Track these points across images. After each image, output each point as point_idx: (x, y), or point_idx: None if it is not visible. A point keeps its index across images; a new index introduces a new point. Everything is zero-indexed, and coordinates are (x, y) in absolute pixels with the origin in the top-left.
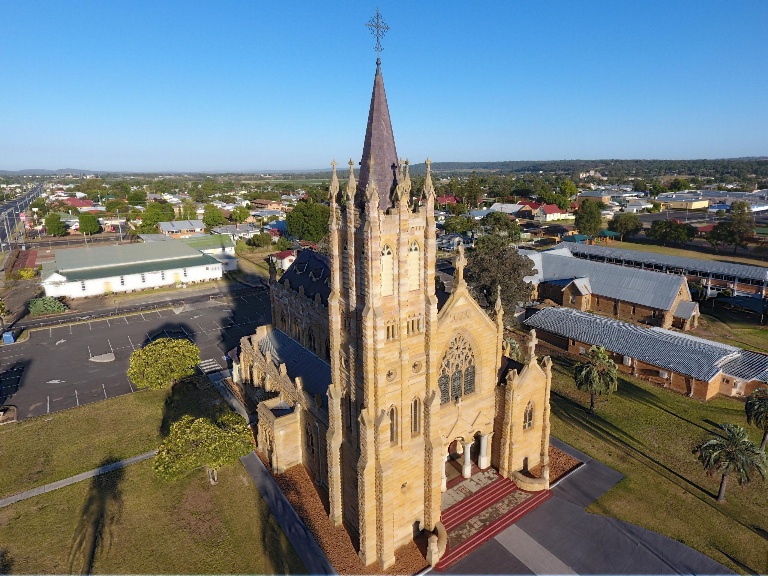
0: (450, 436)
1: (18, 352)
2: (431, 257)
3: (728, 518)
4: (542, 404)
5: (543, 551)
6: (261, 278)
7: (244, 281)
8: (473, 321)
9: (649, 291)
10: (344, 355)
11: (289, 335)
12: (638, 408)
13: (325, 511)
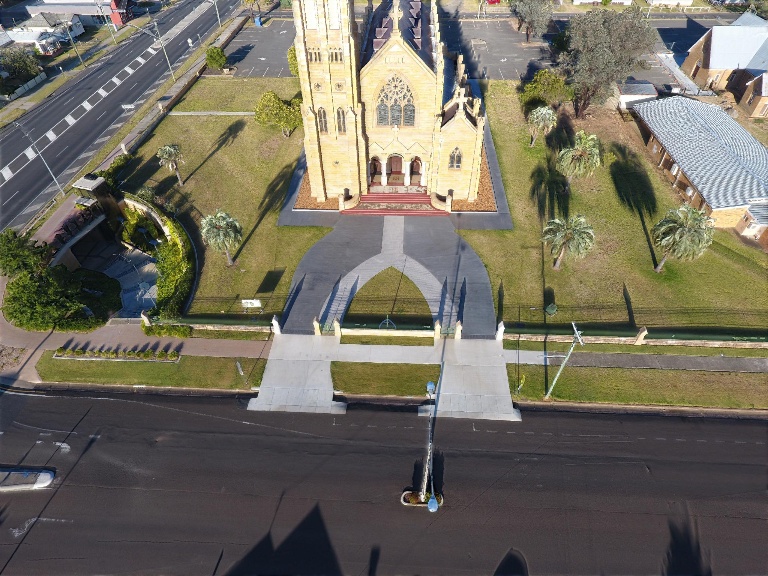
0: (387, 149)
1: (259, 34)
2: (343, 5)
3: (541, 275)
4: (471, 155)
5: (401, 231)
6: (461, 4)
7: (444, 4)
8: (409, 67)
9: None
10: None
11: None
12: (618, 205)
13: None
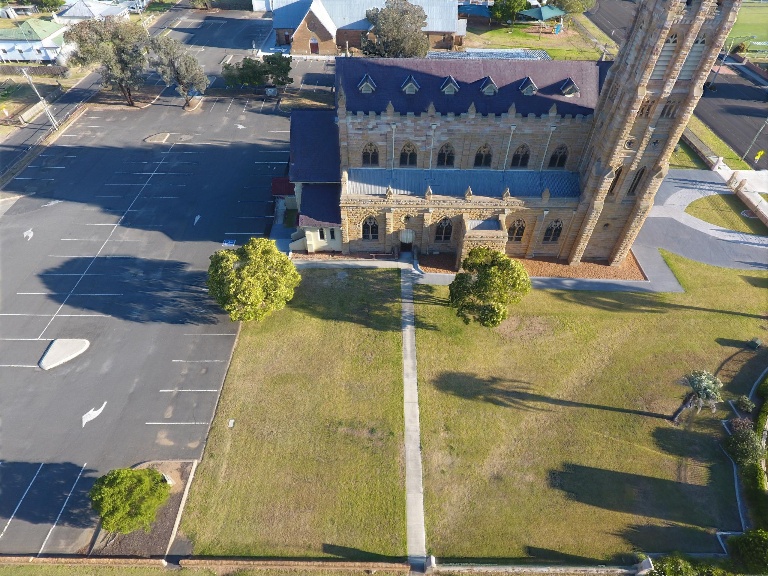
0: None
1: None
2: None
3: None
4: None
5: None
6: None
7: None
8: None
9: (437, 17)
10: (633, 138)
11: (390, 166)
12: None
13: (561, 264)
